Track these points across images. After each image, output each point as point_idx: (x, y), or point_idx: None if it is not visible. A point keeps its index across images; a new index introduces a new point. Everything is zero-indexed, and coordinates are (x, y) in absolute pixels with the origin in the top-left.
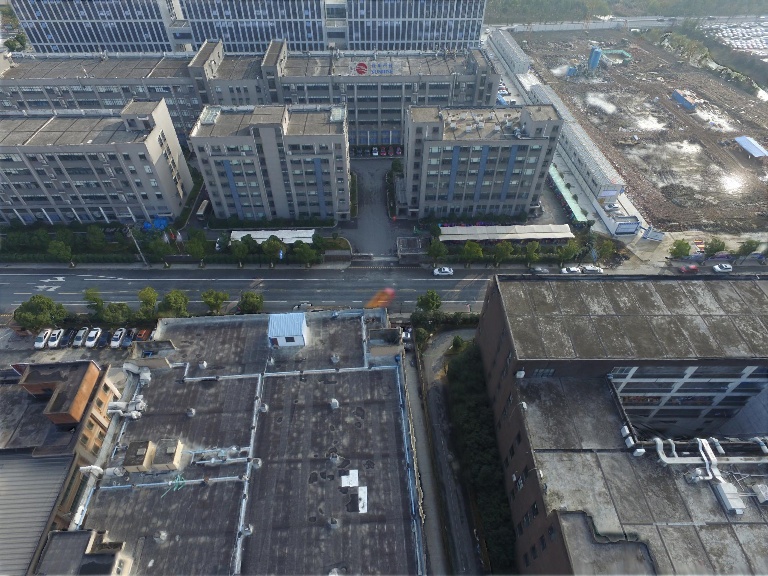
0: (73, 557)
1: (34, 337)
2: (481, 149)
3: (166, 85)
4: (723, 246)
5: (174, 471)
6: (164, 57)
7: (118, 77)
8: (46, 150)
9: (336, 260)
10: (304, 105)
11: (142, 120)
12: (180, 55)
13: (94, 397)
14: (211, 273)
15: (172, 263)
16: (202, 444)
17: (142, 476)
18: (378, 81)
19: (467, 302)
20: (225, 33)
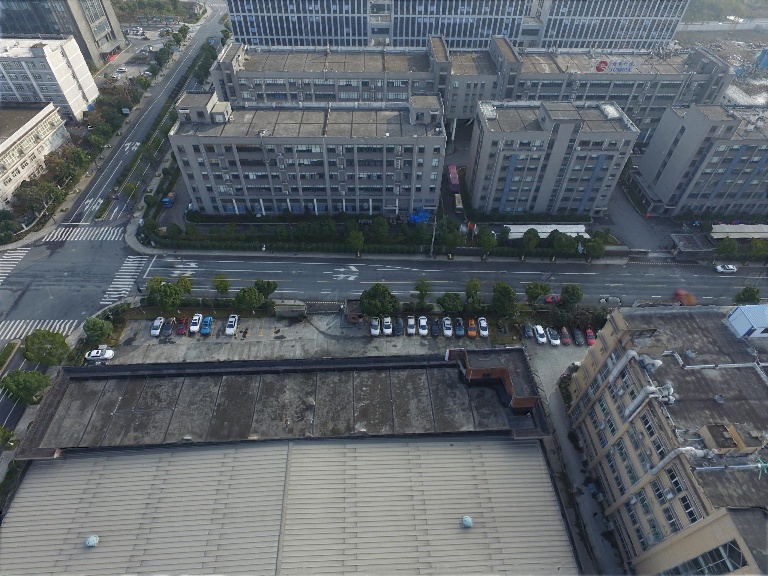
0: (766, 532)
1: (364, 324)
2: (767, 148)
3: (406, 80)
4: None
5: (752, 454)
6: (385, 52)
7: (357, 71)
8: (350, 142)
9: (614, 255)
10: (573, 102)
11: (433, 114)
12: (399, 50)
13: None
14: (497, 266)
15: (454, 255)
16: (755, 429)
17: (724, 458)
18: (613, 79)
19: (766, 299)
20: (424, 29)
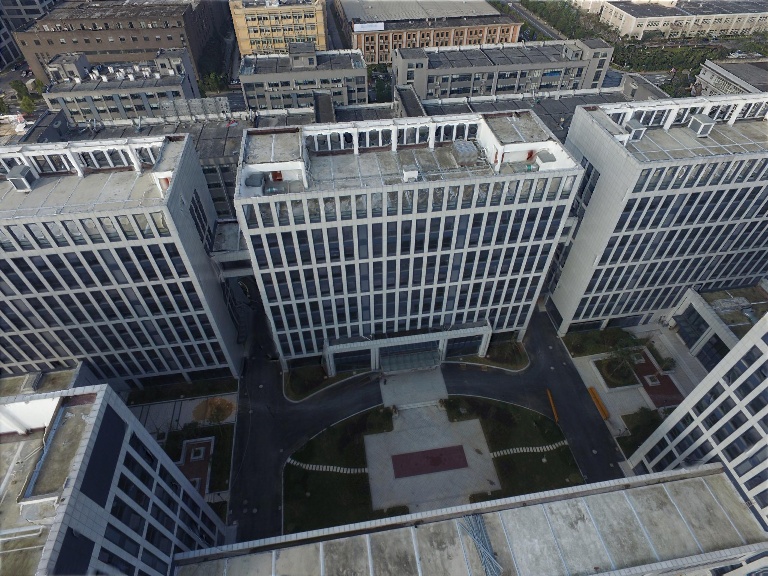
0: None
1: None
2: None
3: None
4: (0, 98)
5: None
6: None
7: None
8: (461, 50)
9: None
10: (278, 73)
11: None
12: None
13: (351, 28)
14: None
15: None
16: None
17: None
18: (197, 121)
19: None
20: None
